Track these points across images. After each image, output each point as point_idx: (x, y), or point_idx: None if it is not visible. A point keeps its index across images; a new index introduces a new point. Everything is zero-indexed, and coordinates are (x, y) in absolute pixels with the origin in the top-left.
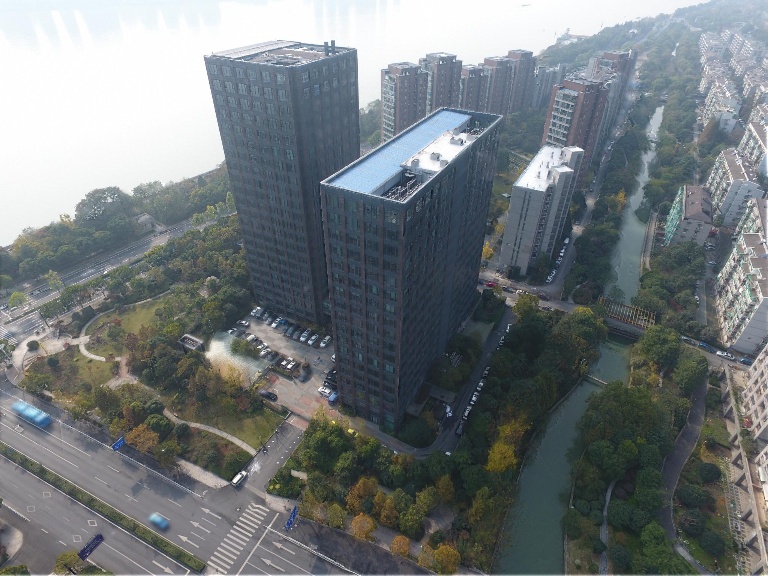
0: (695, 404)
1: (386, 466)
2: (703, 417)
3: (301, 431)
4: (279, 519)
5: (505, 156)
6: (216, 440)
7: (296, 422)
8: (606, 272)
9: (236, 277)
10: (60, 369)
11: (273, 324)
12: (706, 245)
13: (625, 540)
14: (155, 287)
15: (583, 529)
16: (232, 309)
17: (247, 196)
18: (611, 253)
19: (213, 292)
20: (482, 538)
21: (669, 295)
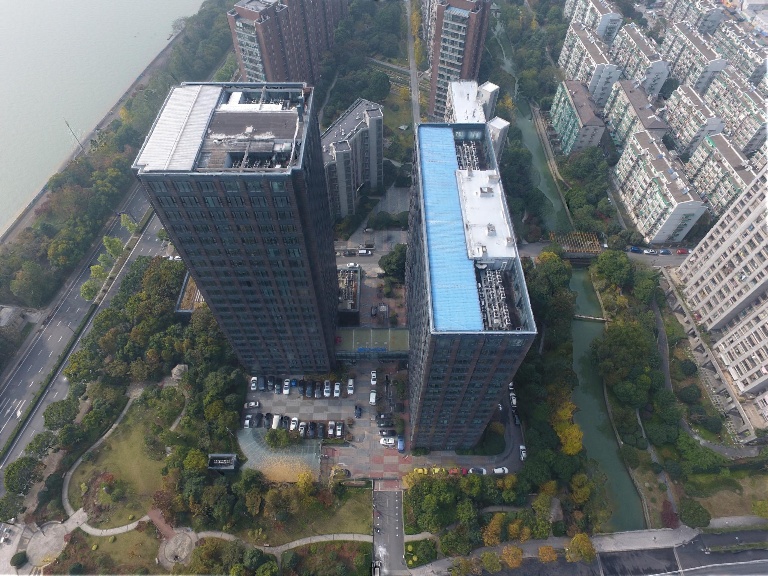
0: (653, 310)
1: (497, 494)
2: (661, 318)
3: (395, 493)
4: None
5: (386, 80)
6: (330, 549)
7: (384, 487)
8: (544, 204)
9: (210, 357)
10: (88, 570)
11: (285, 391)
12: (599, 144)
13: (670, 454)
14: (111, 408)
15: (640, 459)
16: (237, 399)
17: (228, 296)
18: (534, 177)
19: (193, 385)
20: (603, 518)
21: (594, 208)
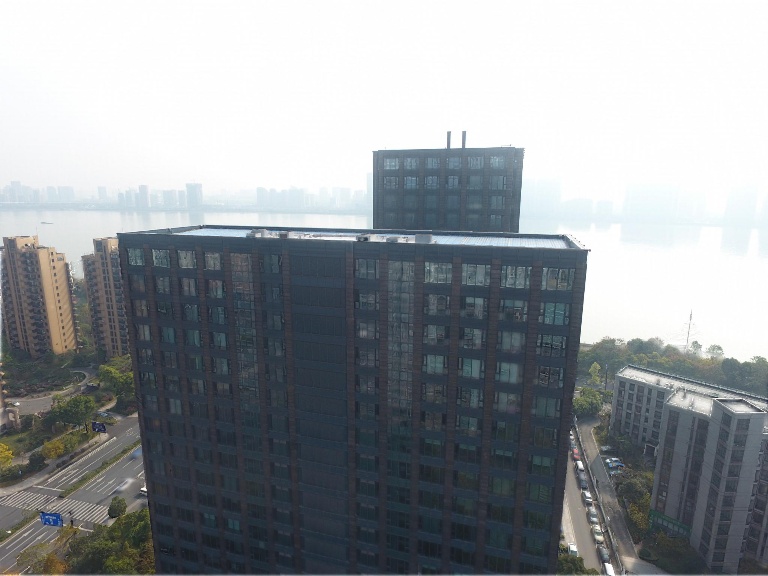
0: None
1: None
2: None
3: None
4: (85, 533)
5: None
6: None
7: None
8: None
9: None
10: None
11: None
12: None
13: None
14: None
15: None
16: None
17: None
18: None
19: None
20: None
21: None
